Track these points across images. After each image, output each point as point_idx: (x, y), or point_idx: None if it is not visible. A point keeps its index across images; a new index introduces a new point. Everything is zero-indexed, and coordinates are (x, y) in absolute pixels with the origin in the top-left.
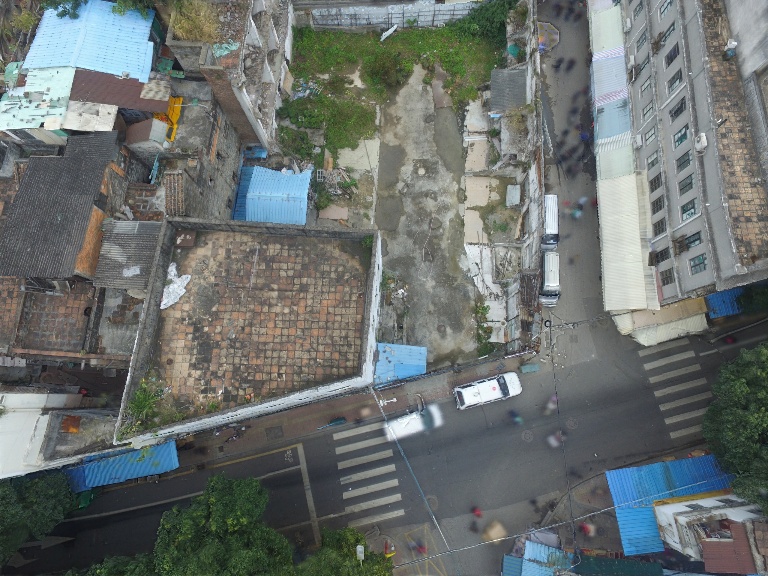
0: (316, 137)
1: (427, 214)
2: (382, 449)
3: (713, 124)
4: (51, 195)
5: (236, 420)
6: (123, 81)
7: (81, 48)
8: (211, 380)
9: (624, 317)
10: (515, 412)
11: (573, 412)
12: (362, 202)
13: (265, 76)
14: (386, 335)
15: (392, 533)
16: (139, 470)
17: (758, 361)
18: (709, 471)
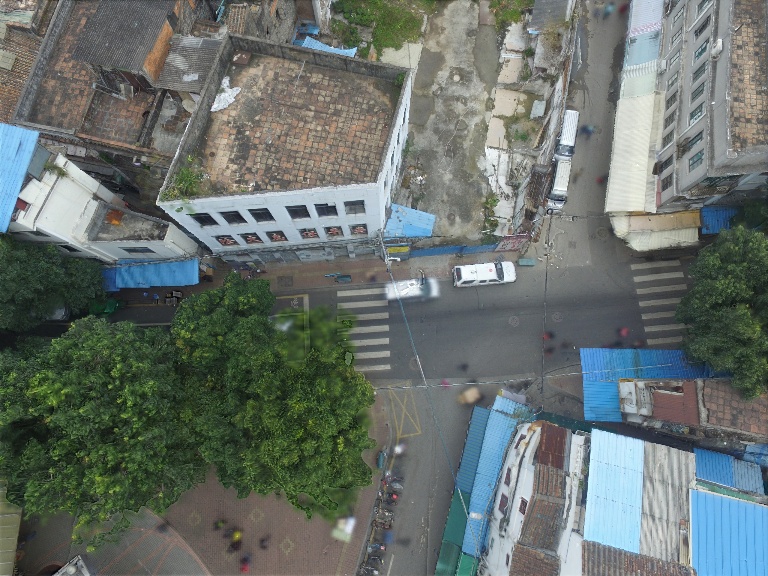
0: (365, 34)
1: (455, 116)
2: (379, 311)
3: (730, 30)
4: (132, 5)
5: (255, 248)
6: None
7: None
8: (245, 174)
9: (622, 221)
10: (506, 299)
11: (560, 307)
12: None
13: None
14: None
15: (376, 383)
16: (163, 280)
17: (733, 238)
18: (676, 362)
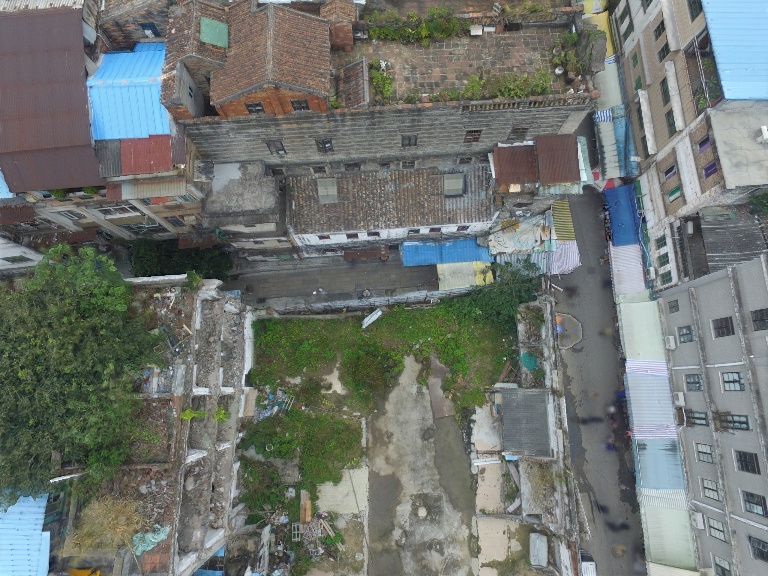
0: (289, 470)
1: (432, 575)
2: None
3: None
4: None
5: None
6: None
7: None
8: None
9: None
10: None
11: None
12: (350, 562)
13: None
14: None
15: None
16: None
17: None
18: None
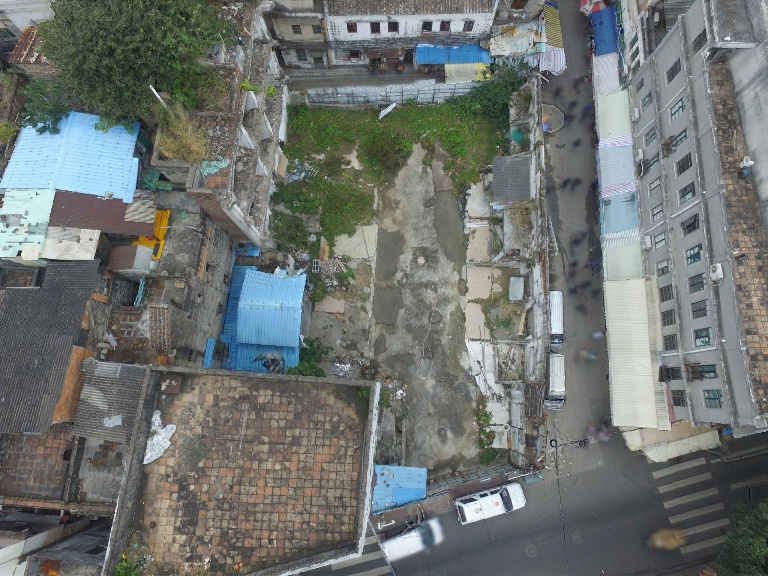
0: (312, 223)
1: (427, 307)
2: (380, 565)
3: (730, 256)
4: (28, 335)
5: None
6: (106, 202)
7: (61, 167)
8: (197, 546)
9: (633, 432)
10: (519, 524)
11: (579, 524)
12: (359, 294)
13: (258, 170)
14: (384, 440)
15: None
16: None
17: None
18: None
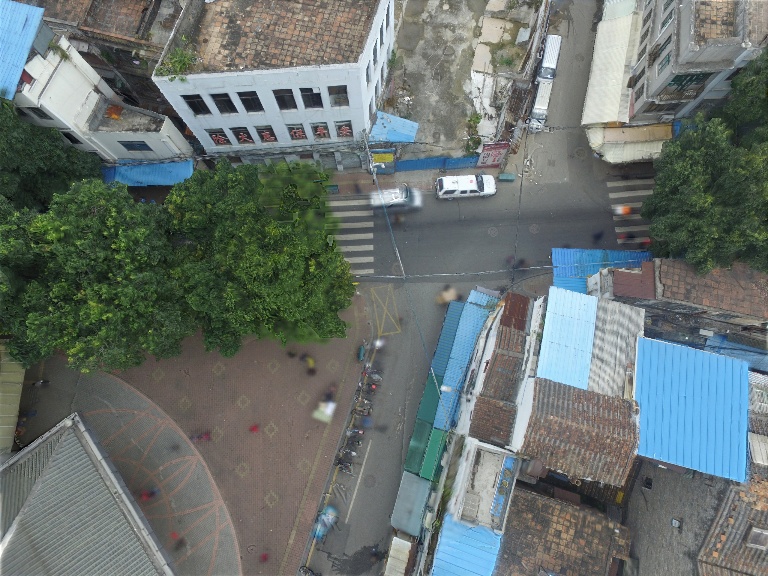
0: None
1: (443, 42)
2: (365, 220)
3: None
4: None
5: (247, 149)
6: None
7: None
8: (236, 58)
9: (597, 134)
10: (486, 212)
11: (537, 220)
12: None
13: None
14: None
15: (360, 286)
16: (160, 180)
17: (693, 126)
18: None
